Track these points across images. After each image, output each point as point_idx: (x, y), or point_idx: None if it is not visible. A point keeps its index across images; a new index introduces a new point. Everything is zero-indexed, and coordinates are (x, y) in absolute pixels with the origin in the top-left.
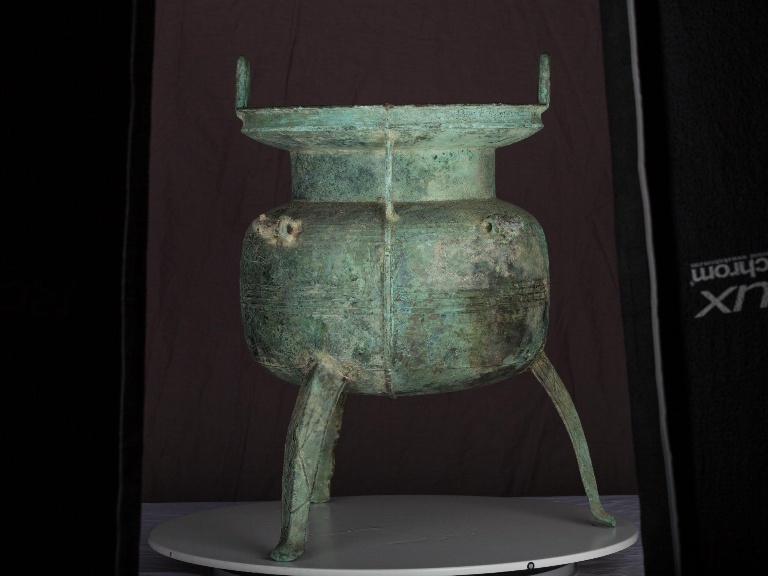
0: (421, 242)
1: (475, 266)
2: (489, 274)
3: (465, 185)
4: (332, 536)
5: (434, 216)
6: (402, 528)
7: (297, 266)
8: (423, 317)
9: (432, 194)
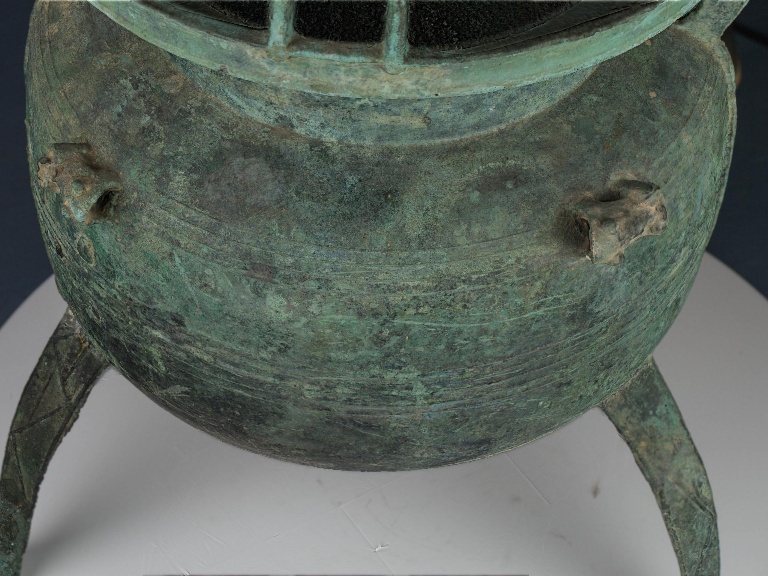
0: None
1: None
2: None
3: None
4: None
5: None
6: None
7: (657, 253)
8: None
9: None
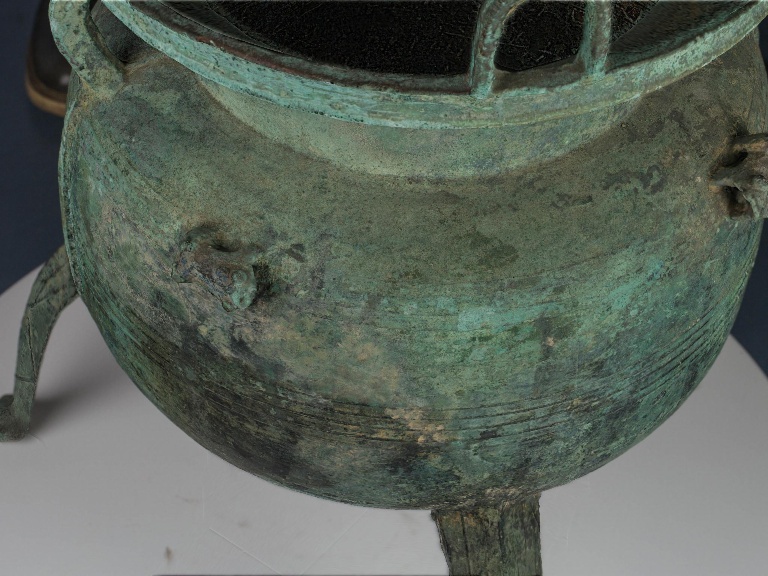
0: (93, 175)
1: (157, 293)
2: (184, 327)
3: (298, 122)
4: None
5: (147, 145)
6: (407, 514)
7: None
8: None
9: (225, 93)
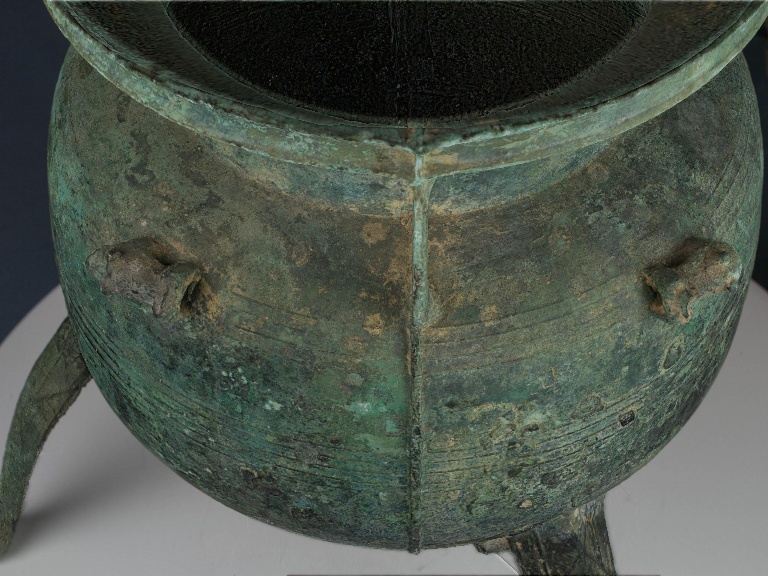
0: None
1: None
2: None
3: None
4: None
5: None
6: None
7: None
8: (332, 3)
9: None
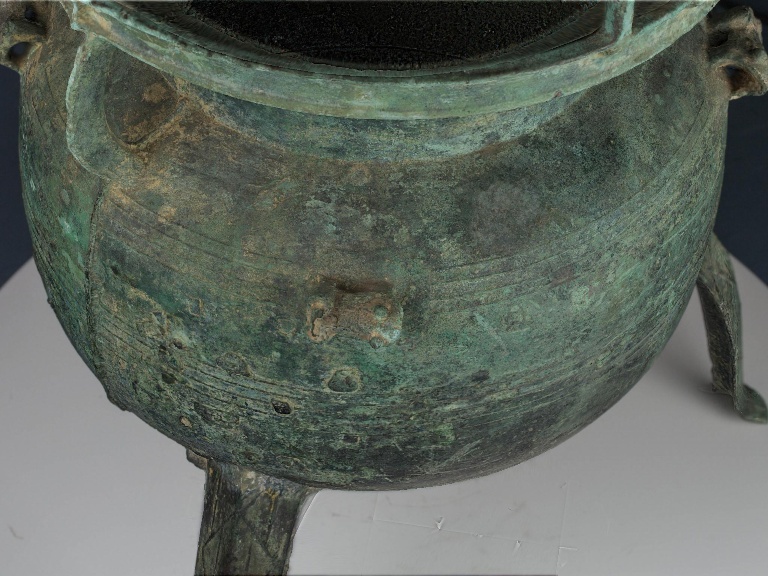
0: None
1: None
2: None
3: None
4: (507, 509)
5: None
6: None
7: None
8: None
9: None
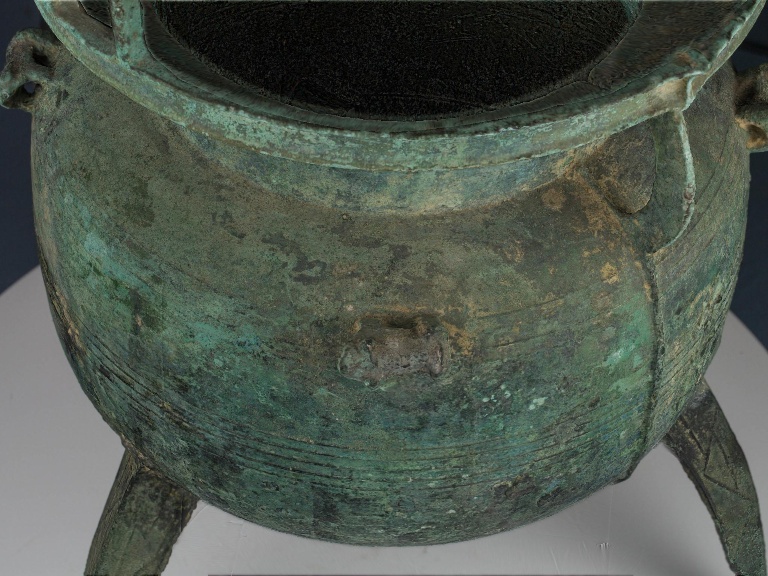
0: None
1: None
2: None
3: None
4: None
5: None
6: None
7: None
8: None
9: None
